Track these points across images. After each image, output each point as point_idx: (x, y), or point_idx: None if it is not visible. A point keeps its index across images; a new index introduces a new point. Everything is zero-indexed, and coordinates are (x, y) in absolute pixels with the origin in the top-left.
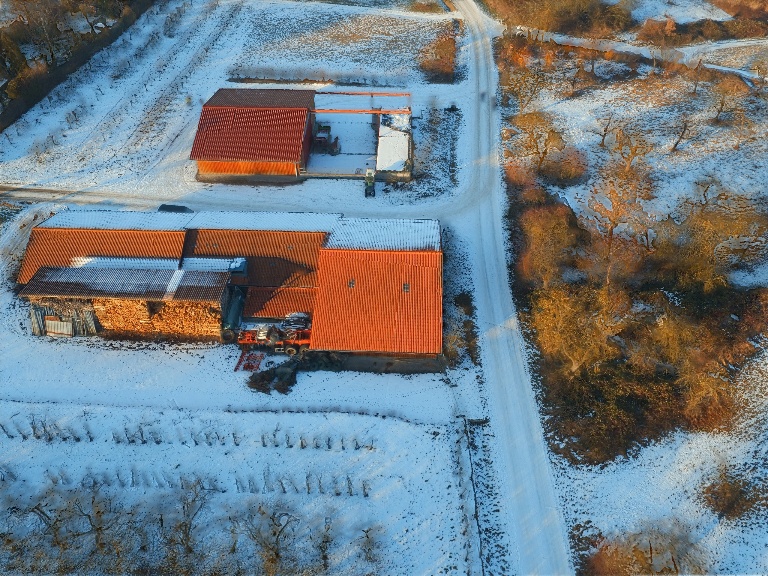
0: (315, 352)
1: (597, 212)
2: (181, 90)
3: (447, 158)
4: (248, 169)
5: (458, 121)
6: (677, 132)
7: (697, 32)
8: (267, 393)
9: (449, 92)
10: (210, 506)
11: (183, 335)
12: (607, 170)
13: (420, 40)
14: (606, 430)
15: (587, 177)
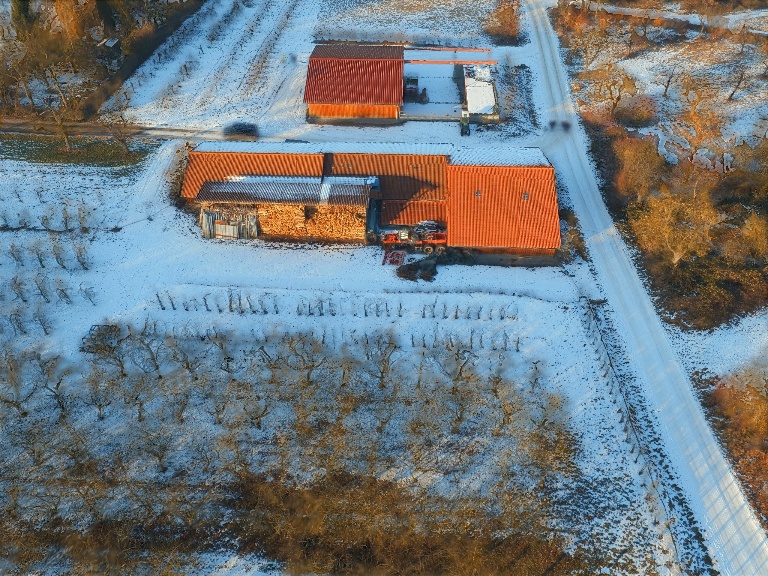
0: (451, 249)
1: None
2: (273, 50)
3: (525, 107)
4: (354, 112)
5: (529, 77)
6: (730, 85)
7: (737, 2)
8: (414, 281)
9: (516, 53)
10: (391, 357)
11: (331, 238)
12: (673, 114)
13: (480, 10)
14: (711, 304)
15: (656, 120)
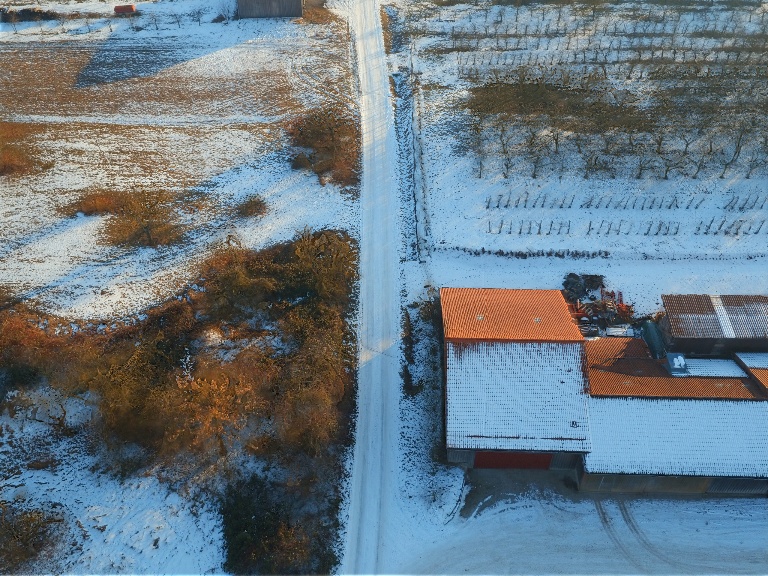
0: None
1: (189, 567)
2: None
3: None
4: None
5: None
6: None
7: None
8: None
9: None
10: None
11: None
12: None
13: None
14: None
15: None
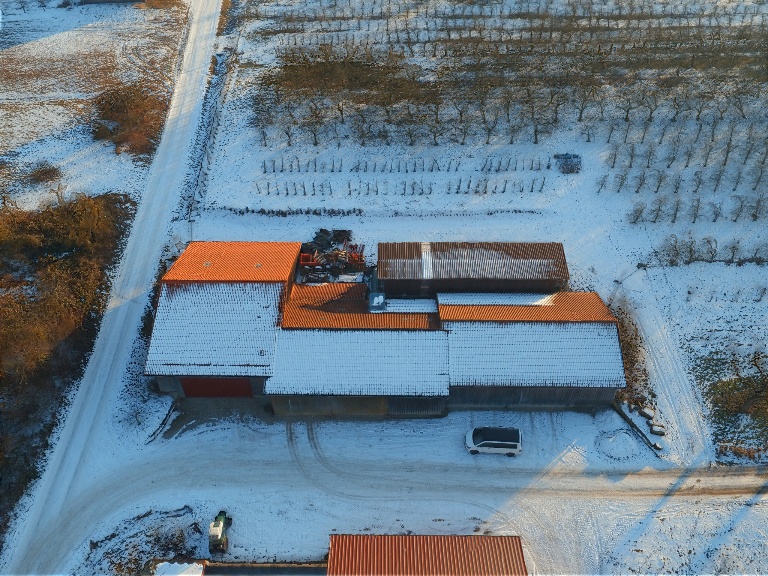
0: None
1: None
2: None
3: None
4: None
5: None
6: None
7: None
8: None
9: None
10: None
11: None
12: None
13: None
14: None
15: None
